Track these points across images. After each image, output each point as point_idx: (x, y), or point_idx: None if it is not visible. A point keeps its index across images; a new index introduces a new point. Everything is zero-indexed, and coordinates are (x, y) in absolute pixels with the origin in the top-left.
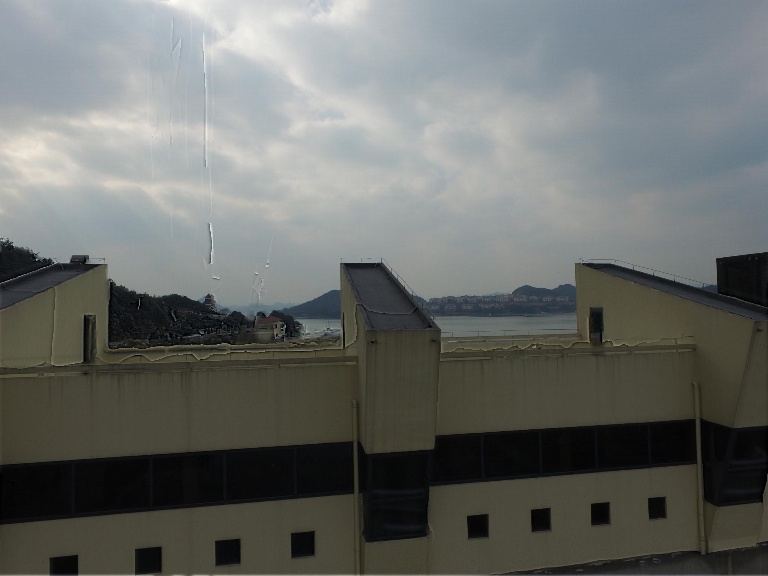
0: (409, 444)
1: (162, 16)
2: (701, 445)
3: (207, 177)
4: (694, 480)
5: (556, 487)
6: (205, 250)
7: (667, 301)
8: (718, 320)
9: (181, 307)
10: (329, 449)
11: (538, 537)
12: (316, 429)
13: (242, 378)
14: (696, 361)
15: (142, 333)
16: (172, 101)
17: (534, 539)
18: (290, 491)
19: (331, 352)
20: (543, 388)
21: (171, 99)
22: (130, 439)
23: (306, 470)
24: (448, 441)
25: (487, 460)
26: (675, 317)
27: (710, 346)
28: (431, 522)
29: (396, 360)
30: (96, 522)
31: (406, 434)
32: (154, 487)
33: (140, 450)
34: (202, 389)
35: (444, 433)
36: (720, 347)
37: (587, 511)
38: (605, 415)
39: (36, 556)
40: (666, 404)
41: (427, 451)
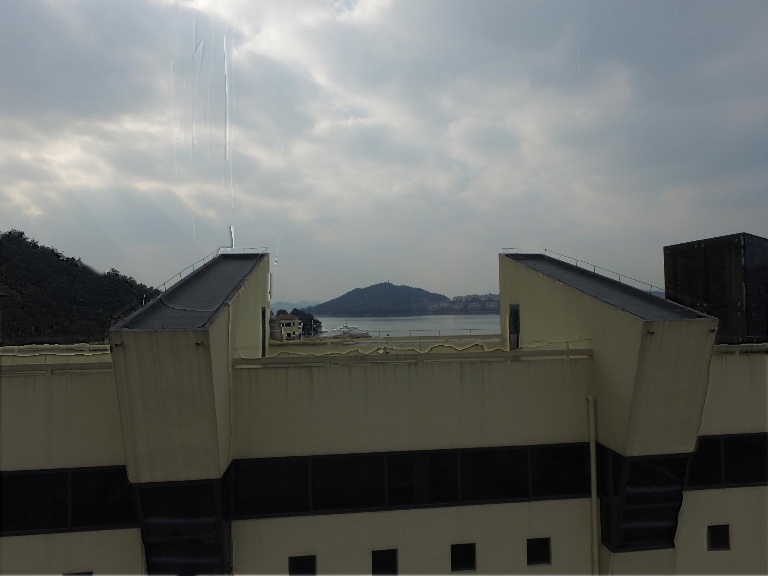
0: (186, 472)
1: (185, 19)
2: (596, 475)
3: None
4: (588, 518)
5: (406, 523)
6: None
7: (568, 296)
8: (611, 319)
9: None
10: (114, 473)
11: None
12: (97, 449)
13: (4, 386)
14: (592, 370)
15: None
16: (194, 102)
17: None
18: (63, 523)
19: None
20: (390, 402)
21: (193, 100)
22: None
23: (84, 498)
24: (266, 465)
25: (316, 489)
26: (575, 316)
27: (605, 352)
28: (242, 563)
29: (154, 368)
30: None
31: (180, 459)
32: None
33: None
34: None
35: (260, 455)
36: (613, 353)
37: (446, 554)
38: (472, 436)
39: None
40: (553, 423)
41: (211, 480)
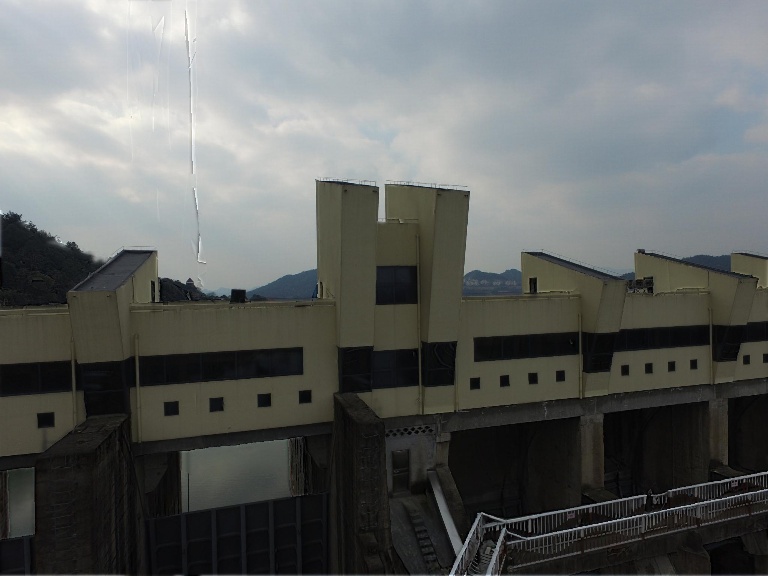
0: None
1: None
2: None
3: (192, 160)
4: None
5: None
6: (193, 234)
7: None
8: None
9: None
10: None
11: None
12: None
13: None
14: None
15: None
16: (155, 81)
17: None
18: None
19: None
20: None
21: (154, 79)
22: (760, 316)
23: None
24: None
25: None
26: None
27: None
28: None
29: None
30: (754, 344)
31: None
32: (766, 333)
33: (763, 320)
34: None
35: None
36: None
37: None
38: None
39: (740, 355)
40: None
41: None
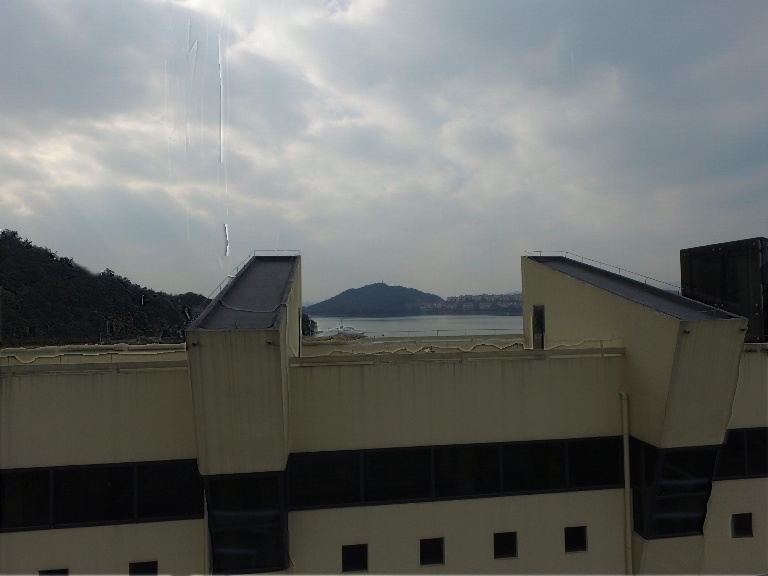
0: (253, 464)
1: (179, 18)
2: (629, 466)
3: (223, 177)
4: (621, 507)
5: (451, 513)
6: (221, 249)
7: (598, 297)
8: (645, 320)
9: (197, 305)
10: (177, 467)
11: (428, 571)
12: (161, 443)
13: (73, 384)
14: (625, 368)
15: (156, 331)
16: (188, 102)
17: (423, 574)
18: (129, 514)
19: (180, 355)
20: (437, 398)
21: (187, 100)
22: None
23: (149, 490)
24: (321, 459)
25: (368, 481)
26: (606, 316)
27: (638, 350)
28: (298, 552)
29: (227, 366)
30: None
31: (248, 452)
32: None
33: None
34: (25, 397)
35: (315, 449)
36: (647, 352)
37: (489, 542)
38: (513, 430)
39: None
40: (589, 418)
41: (276, 472)
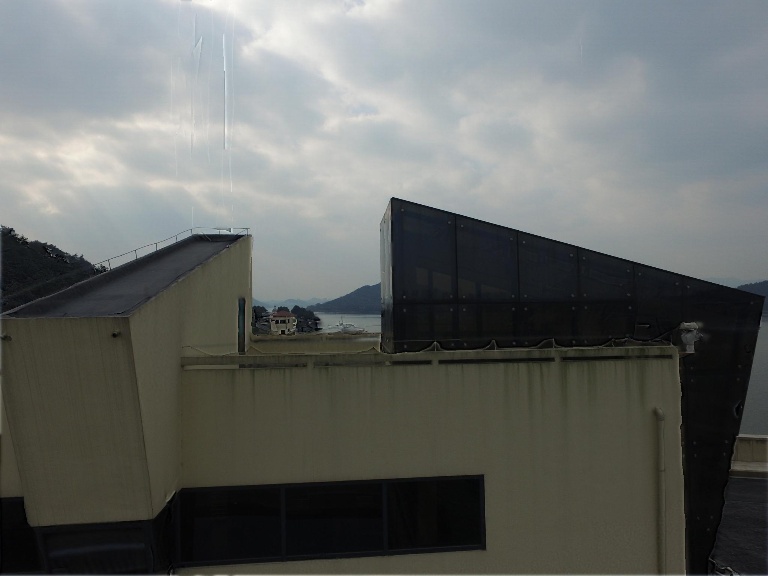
0: None
1: (185, 16)
2: None
3: (228, 173)
4: None
5: None
6: None
7: None
8: None
9: None
10: None
11: None
12: None
13: None
14: None
15: None
16: (193, 99)
17: None
18: None
19: None
20: None
21: (192, 97)
22: None
23: None
24: None
25: None
26: None
27: None
28: None
29: None
30: None
31: None
32: None
33: None
34: None
35: None
36: None
37: None
38: None
39: None
40: (15, 466)
41: None
